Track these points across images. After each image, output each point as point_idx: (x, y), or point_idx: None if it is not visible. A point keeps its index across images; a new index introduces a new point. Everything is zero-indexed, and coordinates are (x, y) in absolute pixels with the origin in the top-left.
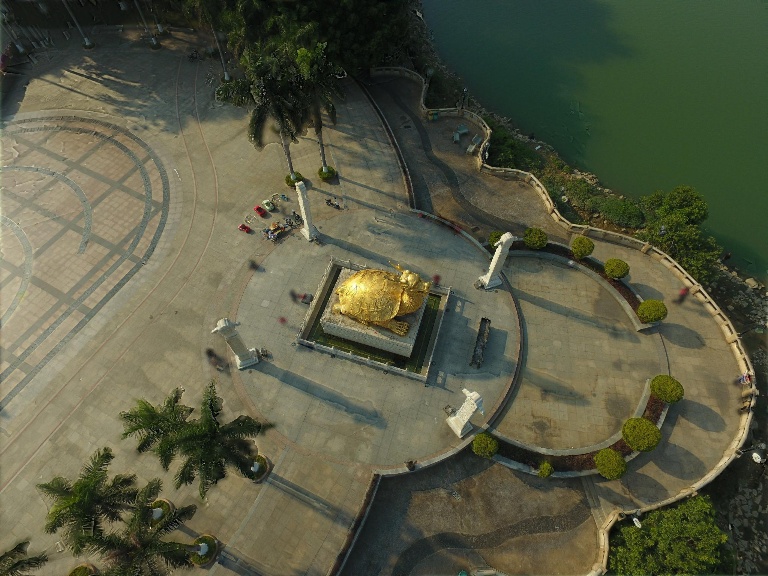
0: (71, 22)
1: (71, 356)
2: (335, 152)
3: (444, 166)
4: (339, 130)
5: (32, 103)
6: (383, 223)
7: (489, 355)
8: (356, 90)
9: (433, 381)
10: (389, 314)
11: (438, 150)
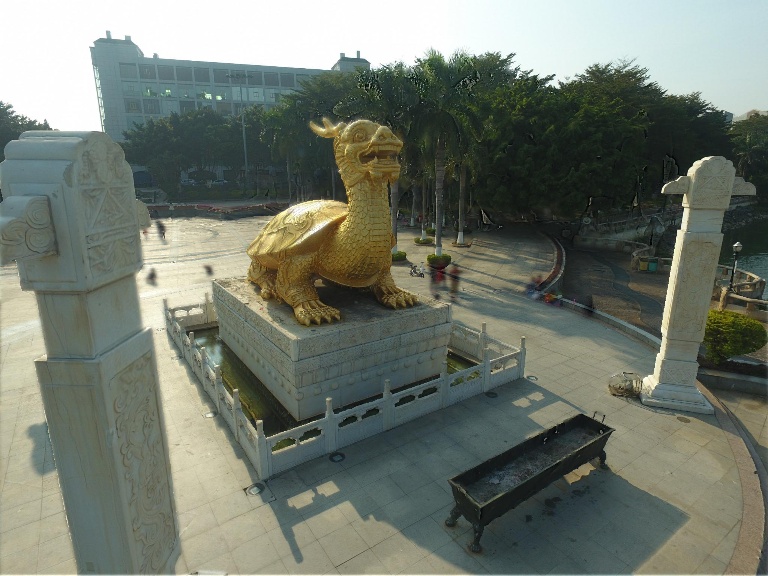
0: (330, 192)
1: (7, 278)
2: (469, 254)
3: (642, 296)
4: (492, 248)
5: (261, 217)
6: (471, 293)
7: (555, 538)
8: (542, 240)
9: (282, 491)
10: (294, 239)
11: (640, 287)
